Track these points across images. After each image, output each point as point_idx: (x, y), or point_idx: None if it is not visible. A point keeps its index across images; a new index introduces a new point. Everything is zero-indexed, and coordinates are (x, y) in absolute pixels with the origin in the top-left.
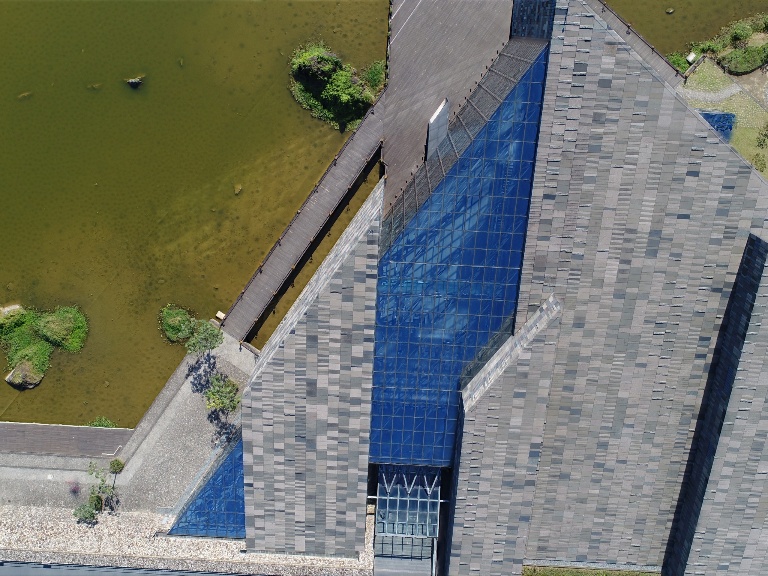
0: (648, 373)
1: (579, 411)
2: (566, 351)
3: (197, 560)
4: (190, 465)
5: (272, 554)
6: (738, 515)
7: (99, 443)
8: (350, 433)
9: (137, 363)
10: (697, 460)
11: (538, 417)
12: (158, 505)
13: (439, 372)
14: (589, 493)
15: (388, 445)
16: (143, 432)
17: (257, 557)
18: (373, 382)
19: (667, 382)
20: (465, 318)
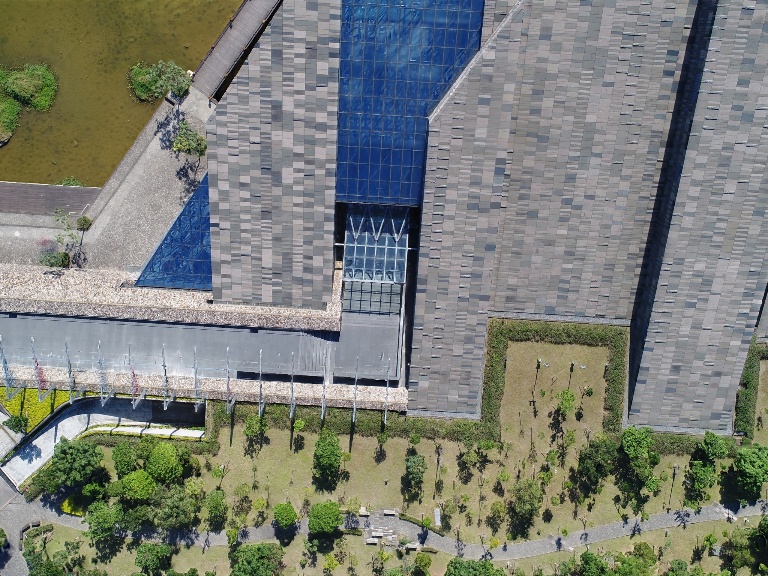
0: (616, 93)
1: (546, 138)
2: (533, 68)
3: (163, 308)
4: (158, 223)
5: (239, 305)
6: (705, 243)
7: (67, 202)
8: (316, 164)
9: (106, 122)
10: (665, 191)
11: (503, 128)
12: (126, 263)
13: (405, 95)
14: (557, 234)
15: (355, 181)
16: (111, 190)
17: (223, 306)
18: (339, 109)
19: (635, 104)
20: (431, 32)
